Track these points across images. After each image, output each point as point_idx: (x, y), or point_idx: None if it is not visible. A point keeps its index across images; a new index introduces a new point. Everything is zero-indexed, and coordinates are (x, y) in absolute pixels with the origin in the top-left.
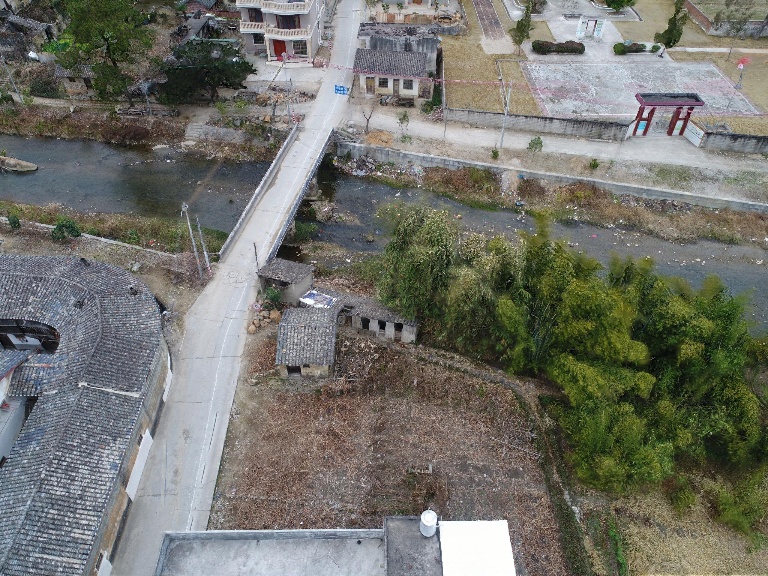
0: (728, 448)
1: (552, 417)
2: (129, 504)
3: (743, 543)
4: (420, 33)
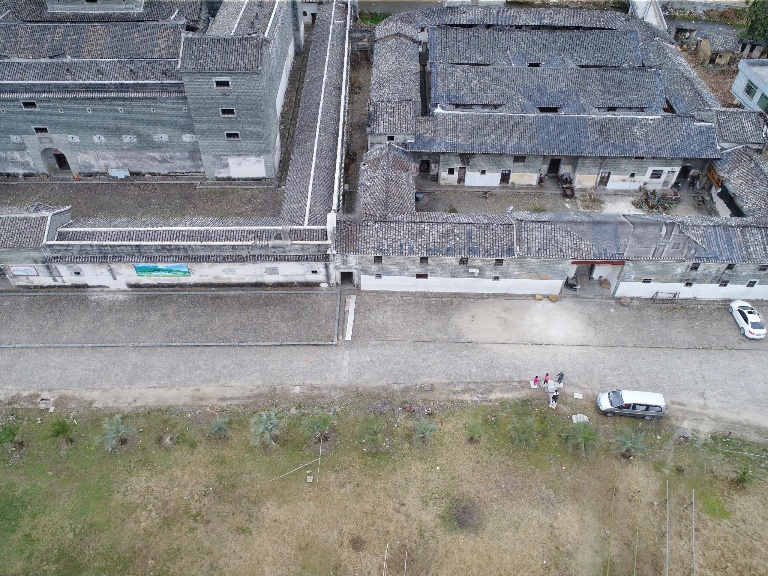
0: None
1: None
2: None
3: None
4: None
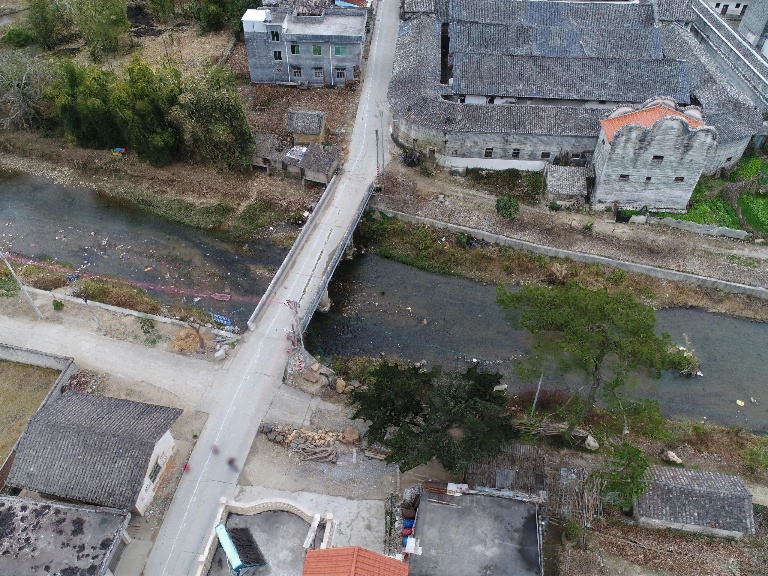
0: None
1: None
2: None
3: None
4: None
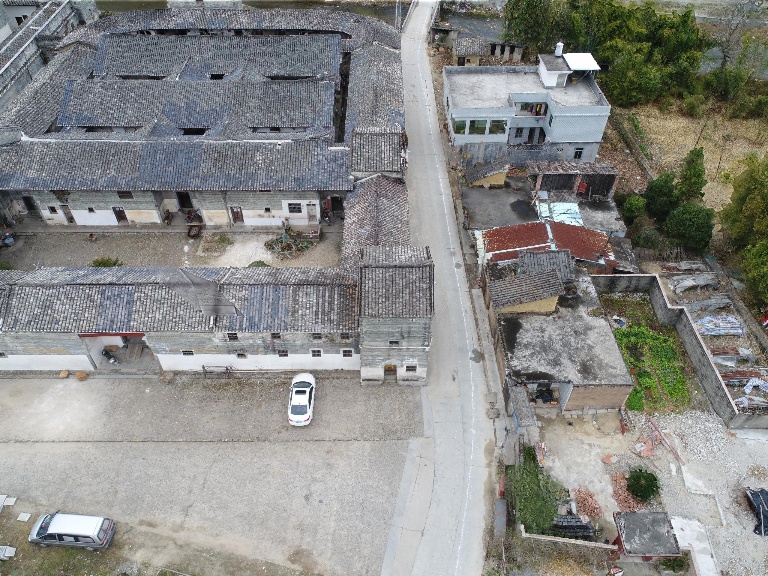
0: (688, 81)
1: (599, 79)
2: None
3: (695, 122)
4: None
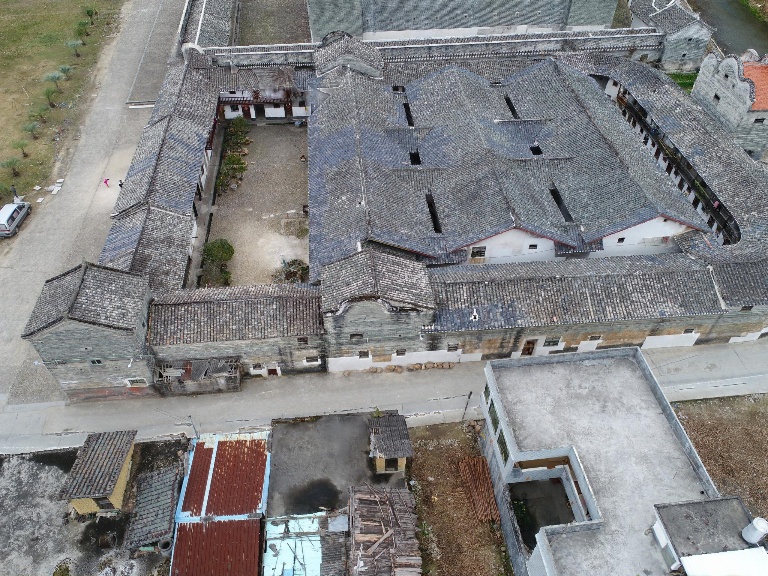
0: None
1: None
2: None
3: None
4: None
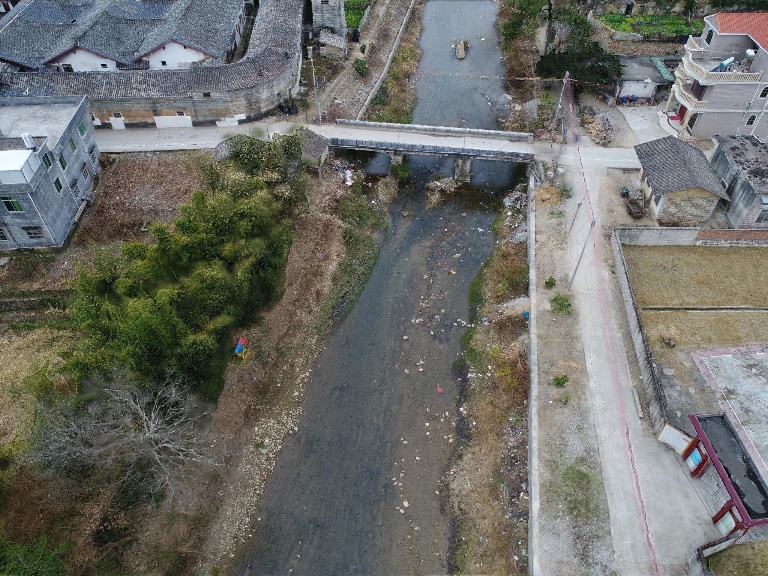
0: None
1: None
2: (154, 125)
3: (31, 405)
4: (763, 180)
